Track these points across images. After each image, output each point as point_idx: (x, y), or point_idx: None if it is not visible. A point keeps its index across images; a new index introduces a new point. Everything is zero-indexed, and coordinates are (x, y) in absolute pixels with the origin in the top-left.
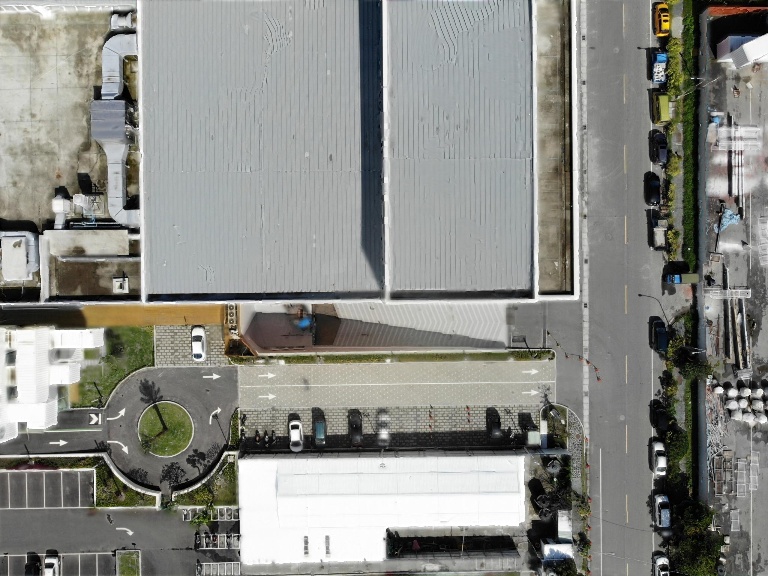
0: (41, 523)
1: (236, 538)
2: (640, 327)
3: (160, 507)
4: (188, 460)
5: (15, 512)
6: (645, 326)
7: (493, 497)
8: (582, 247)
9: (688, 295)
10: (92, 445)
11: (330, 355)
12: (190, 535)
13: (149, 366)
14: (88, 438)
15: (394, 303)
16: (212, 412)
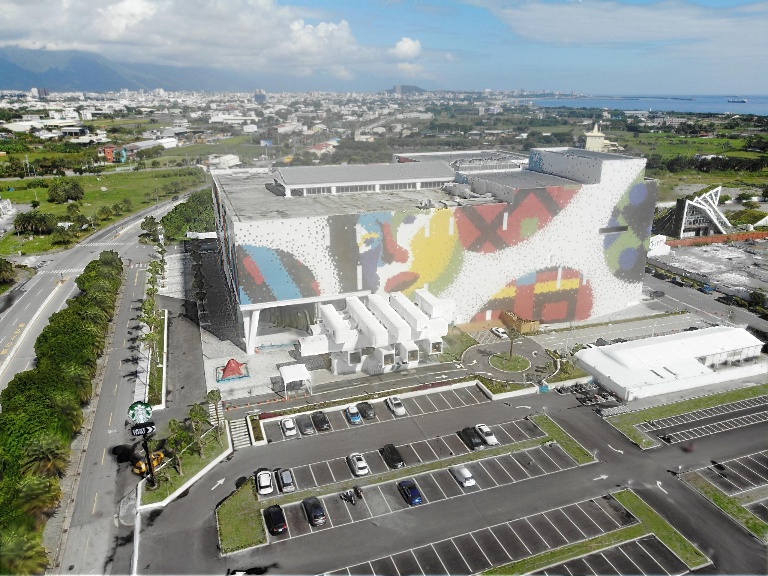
0: (455, 417)
1: (607, 395)
2: (715, 302)
3: (539, 387)
4: (536, 371)
5: (430, 415)
6: (716, 301)
7: (732, 332)
8: (654, 291)
9: (720, 293)
10: (466, 375)
11: (577, 326)
12: (573, 400)
13: (477, 344)
14: (461, 373)
15: (605, 161)
16: (532, 352)
